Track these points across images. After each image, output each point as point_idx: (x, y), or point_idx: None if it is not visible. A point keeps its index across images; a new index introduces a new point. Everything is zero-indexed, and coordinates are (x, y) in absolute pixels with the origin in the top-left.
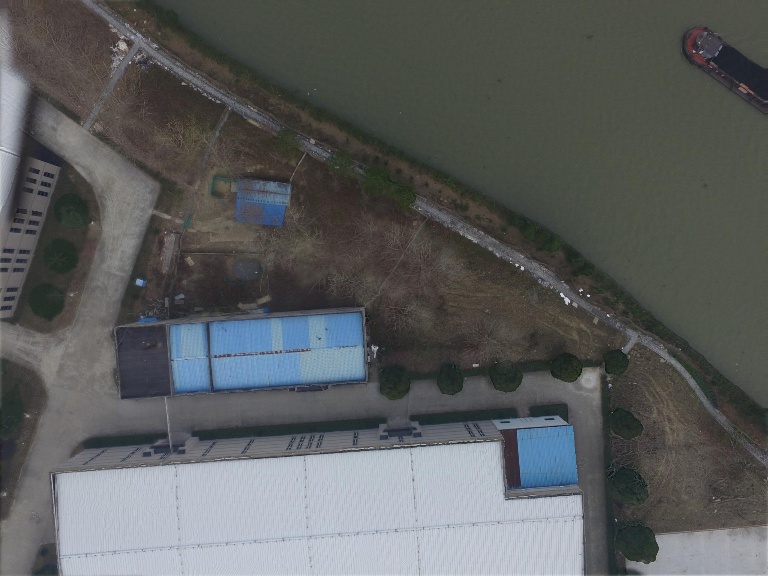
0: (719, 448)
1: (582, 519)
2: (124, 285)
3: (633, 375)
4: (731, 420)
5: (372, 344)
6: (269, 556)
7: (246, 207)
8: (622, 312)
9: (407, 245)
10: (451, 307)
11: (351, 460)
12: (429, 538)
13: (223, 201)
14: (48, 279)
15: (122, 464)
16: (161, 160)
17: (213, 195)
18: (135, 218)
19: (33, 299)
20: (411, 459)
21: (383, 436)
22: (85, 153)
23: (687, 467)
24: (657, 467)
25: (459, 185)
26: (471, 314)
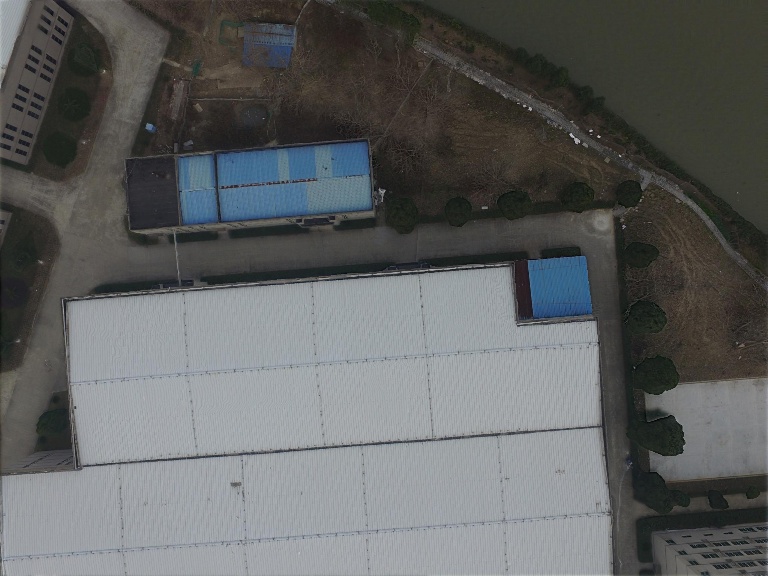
0: (741, 291)
1: (598, 346)
2: (134, 133)
3: (648, 215)
4: (753, 264)
5: (379, 187)
6: (277, 387)
7: (253, 49)
8: (634, 152)
9: (413, 85)
10: (458, 147)
11: (359, 286)
12: (439, 366)
13: (230, 48)
14: (61, 127)
15: None
16: (170, 9)
17: (220, 40)
18: (145, 67)
19: (47, 147)
20: (419, 285)
21: (391, 268)
22: (97, 5)
23: (708, 308)
24: (676, 308)
25: (464, 26)
26: (479, 154)
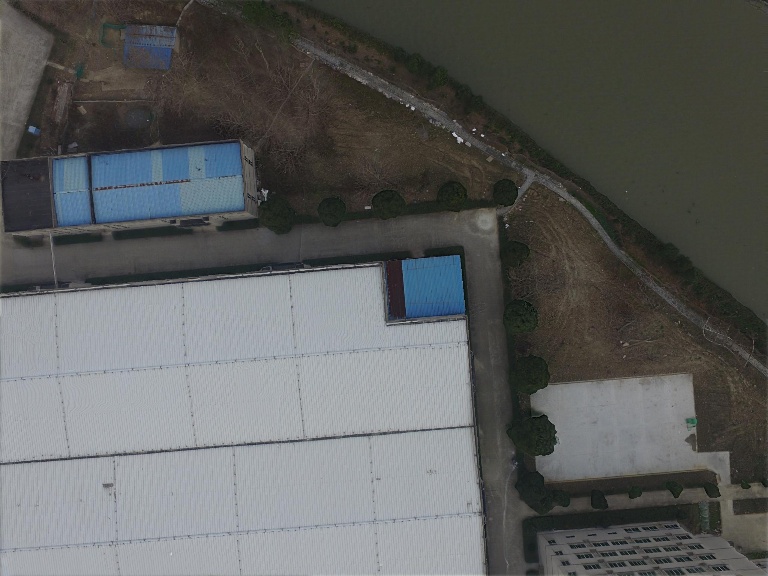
0: (625, 290)
1: (467, 345)
2: (20, 135)
3: (530, 214)
4: (638, 262)
5: (262, 188)
6: (150, 388)
7: (133, 51)
8: (518, 151)
9: (294, 86)
10: (340, 147)
11: (229, 287)
12: (309, 366)
13: (114, 50)
14: None
15: (3, 293)
16: (54, 12)
17: (103, 42)
18: (30, 70)
19: None
20: (290, 285)
21: (265, 268)
22: None
23: (589, 307)
24: (557, 307)
25: (346, 26)
26: (360, 154)
